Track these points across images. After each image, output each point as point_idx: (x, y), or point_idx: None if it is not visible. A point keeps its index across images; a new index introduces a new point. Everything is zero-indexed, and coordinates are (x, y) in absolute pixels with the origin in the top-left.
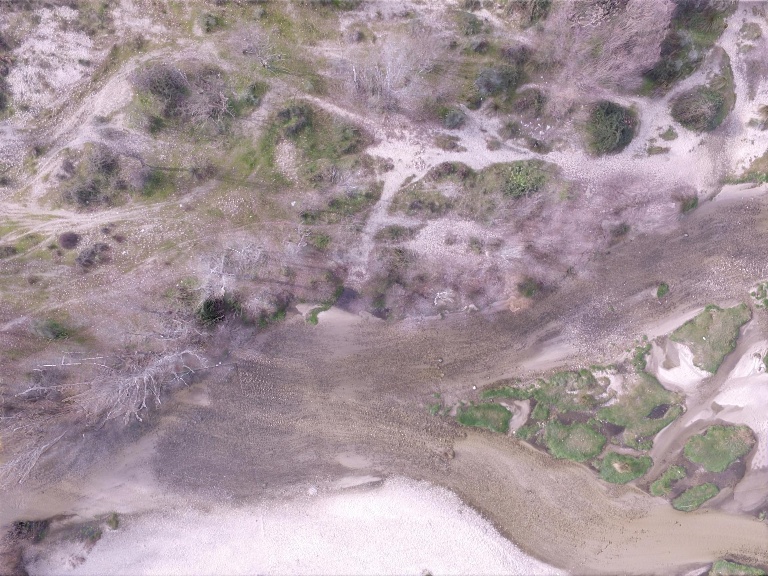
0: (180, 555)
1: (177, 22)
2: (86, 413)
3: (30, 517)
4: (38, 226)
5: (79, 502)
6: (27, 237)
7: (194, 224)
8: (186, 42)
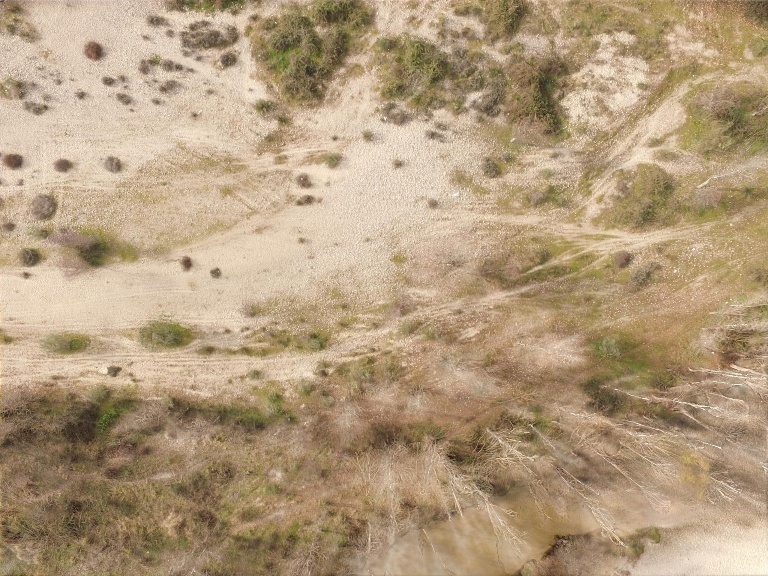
0: (726, 568)
1: (729, 46)
2: (738, 430)
3: (571, 531)
4: (592, 245)
5: (619, 516)
6: (583, 256)
7: (744, 243)
8: (737, 65)
